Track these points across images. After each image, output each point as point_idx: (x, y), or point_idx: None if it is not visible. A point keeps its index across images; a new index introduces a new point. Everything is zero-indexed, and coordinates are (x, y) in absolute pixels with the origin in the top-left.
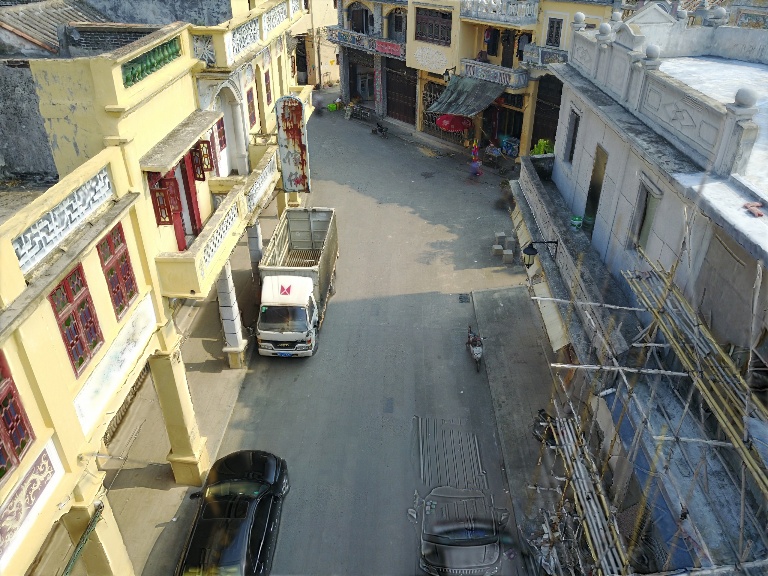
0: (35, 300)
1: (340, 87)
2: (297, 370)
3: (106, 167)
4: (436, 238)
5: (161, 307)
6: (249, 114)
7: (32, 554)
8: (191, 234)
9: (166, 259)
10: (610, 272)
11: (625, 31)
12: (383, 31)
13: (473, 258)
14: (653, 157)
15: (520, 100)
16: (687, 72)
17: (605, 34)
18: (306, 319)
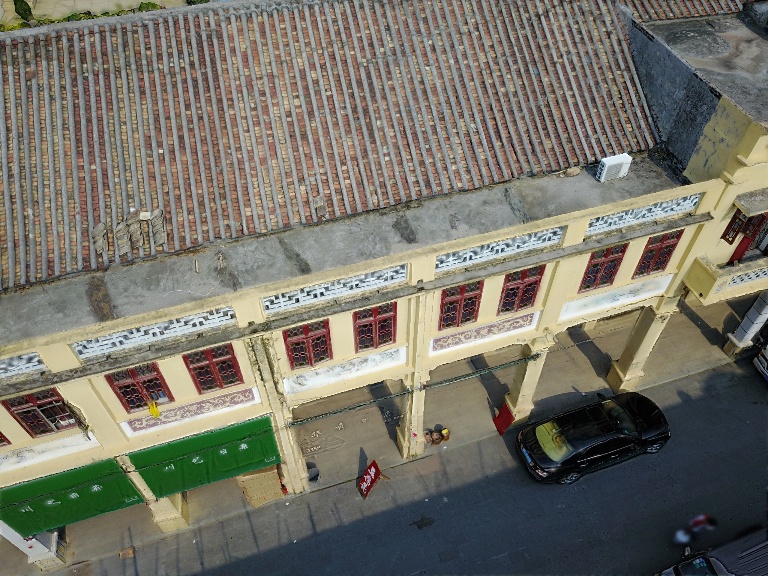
0: (577, 253)
1: None
2: (766, 399)
3: (702, 193)
4: None
5: (675, 286)
6: None
7: (491, 349)
8: (761, 250)
9: (702, 264)
10: None
11: None
12: None
13: None
14: None
15: None
16: None
17: None
18: None
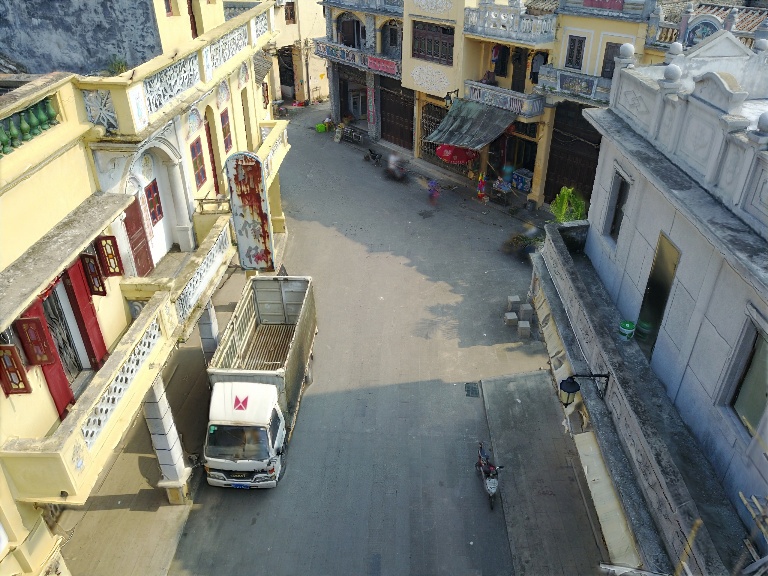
0: None
1: (330, 105)
2: (257, 505)
3: None
4: (437, 300)
5: (15, 518)
6: (195, 172)
7: None
8: (89, 368)
9: (15, 454)
10: (686, 423)
11: (712, 83)
12: (376, 45)
13: (481, 330)
14: None
15: (533, 128)
16: None
17: (673, 80)
18: (267, 443)
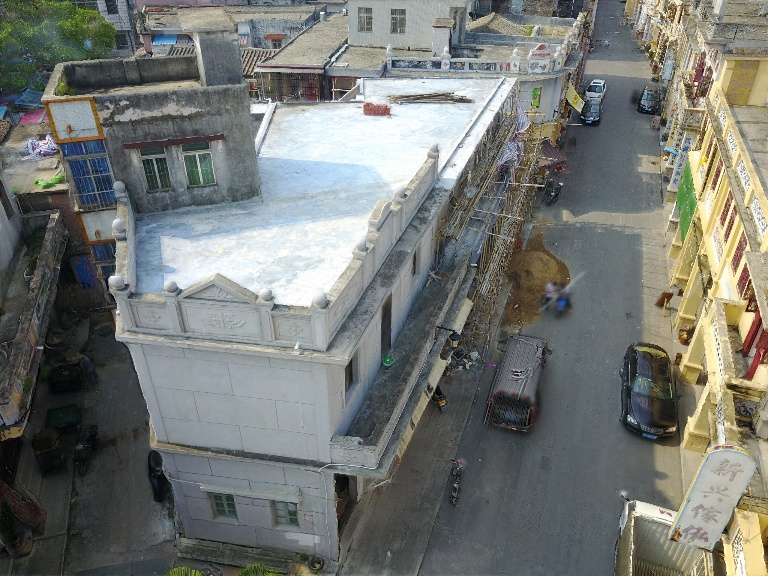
0: None
1: None
2: None
3: None
4: None
5: None
6: None
7: None
8: None
9: None
10: None
11: None
12: None
13: None
14: (444, 200)
15: None
16: (252, 281)
17: None
18: None
